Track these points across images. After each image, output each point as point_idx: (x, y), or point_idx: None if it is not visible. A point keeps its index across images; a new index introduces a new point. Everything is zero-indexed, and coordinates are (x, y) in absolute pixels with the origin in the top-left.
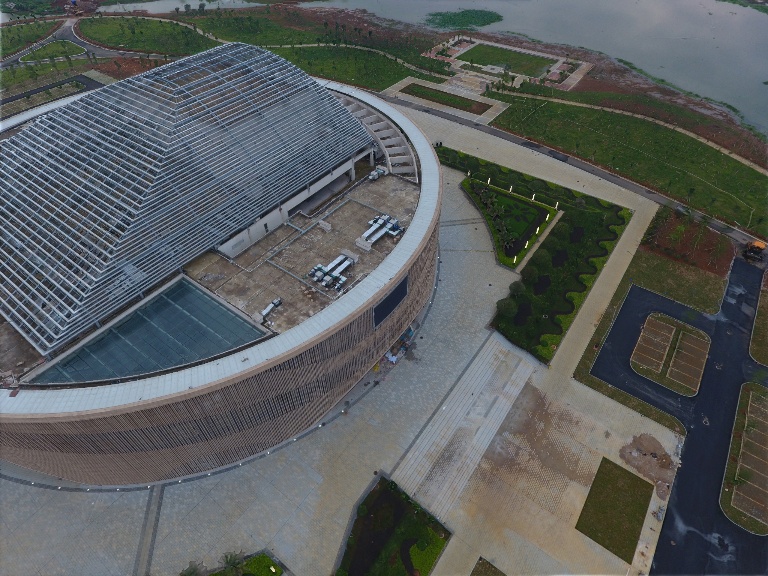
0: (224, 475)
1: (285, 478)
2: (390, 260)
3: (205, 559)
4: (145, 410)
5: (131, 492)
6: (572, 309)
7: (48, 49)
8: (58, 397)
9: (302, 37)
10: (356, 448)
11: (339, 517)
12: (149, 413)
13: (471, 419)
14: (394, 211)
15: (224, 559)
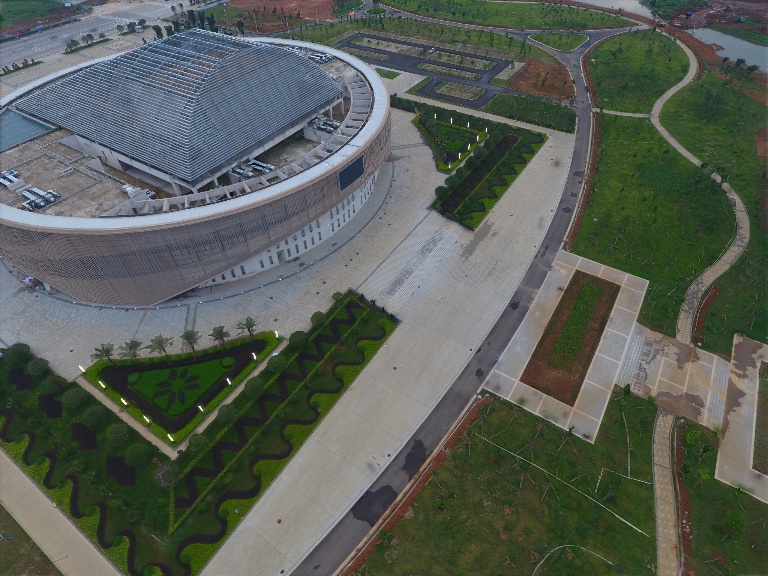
0: None
1: None
2: None
3: None
4: None
5: None
6: (5, 438)
7: None
8: None
9: (728, 156)
10: None
11: None
12: None
13: None
14: (65, 205)
15: None
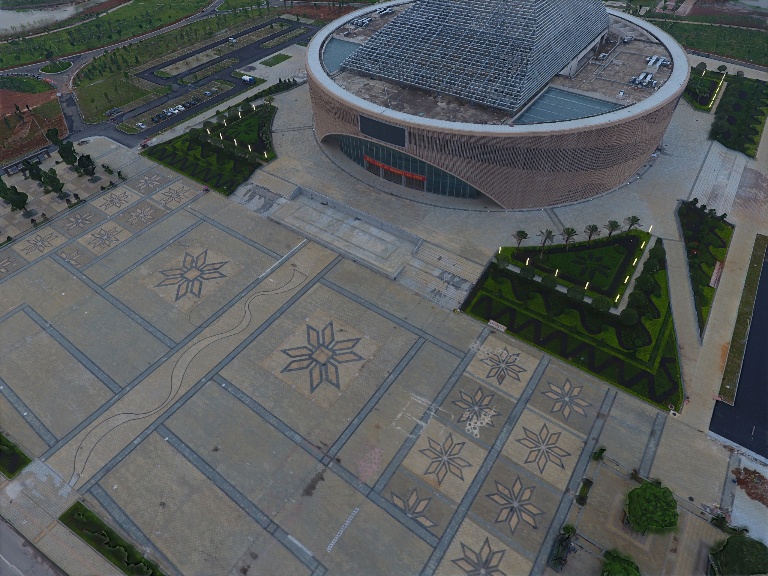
0: (585, 203)
1: (623, 204)
2: (676, 74)
3: (601, 233)
4: (589, 131)
5: (534, 211)
6: (757, 133)
7: (234, 2)
8: (538, 126)
9: None
10: (658, 191)
11: (668, 216)
12: (589, 134)
13: (720, 181)
14: None
15: (628, 219)
